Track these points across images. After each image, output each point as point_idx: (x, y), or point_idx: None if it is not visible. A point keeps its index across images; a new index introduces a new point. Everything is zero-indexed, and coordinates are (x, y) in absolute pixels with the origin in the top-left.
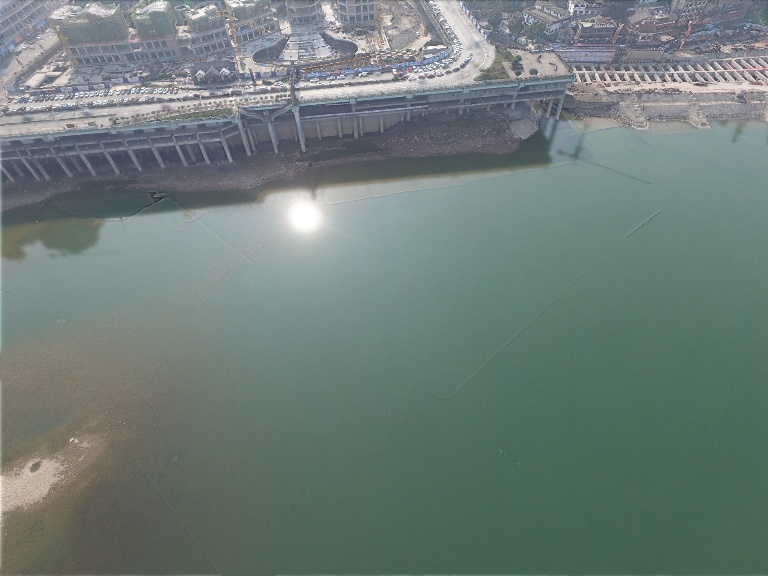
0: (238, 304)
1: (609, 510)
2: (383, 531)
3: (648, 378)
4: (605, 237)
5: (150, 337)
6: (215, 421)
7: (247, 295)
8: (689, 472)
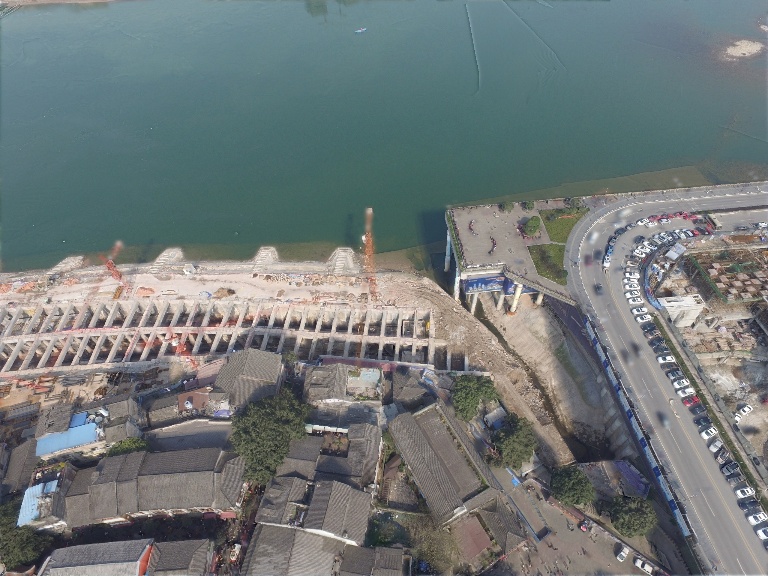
0: (706, 106)
1: None
2: (570, 59)
3: None
4: (493, 24)
5: (747, 91)
6: (671, 67)
7: (704, 110)
8: (440, 64)
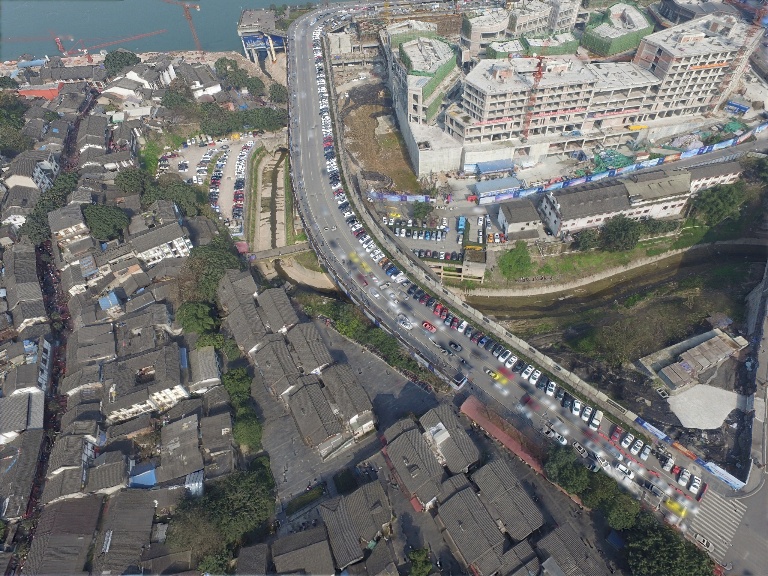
0: None
1: None
2: None
3: None
4: None
5: None
6: None
7: None
8: None
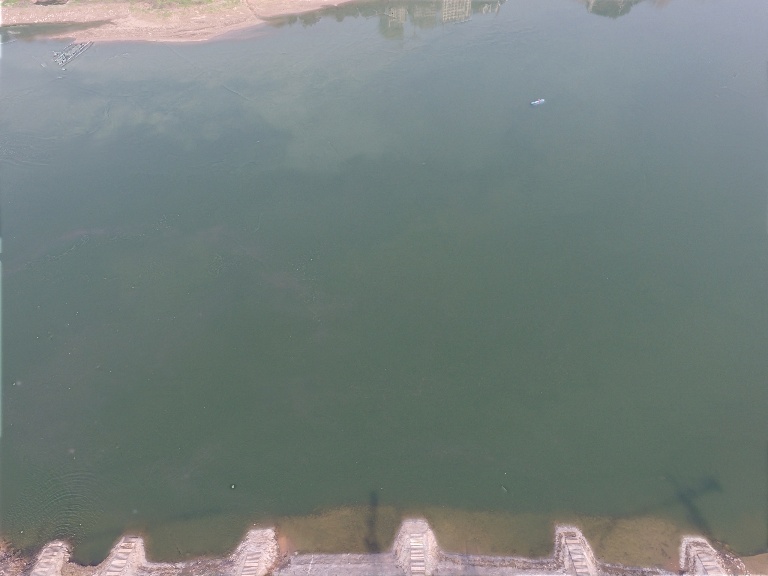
0: None
1: (704, 153)
2: None
3: (683, 199)
4: None
5: None
6: None
7: None
8: (661, 159)
